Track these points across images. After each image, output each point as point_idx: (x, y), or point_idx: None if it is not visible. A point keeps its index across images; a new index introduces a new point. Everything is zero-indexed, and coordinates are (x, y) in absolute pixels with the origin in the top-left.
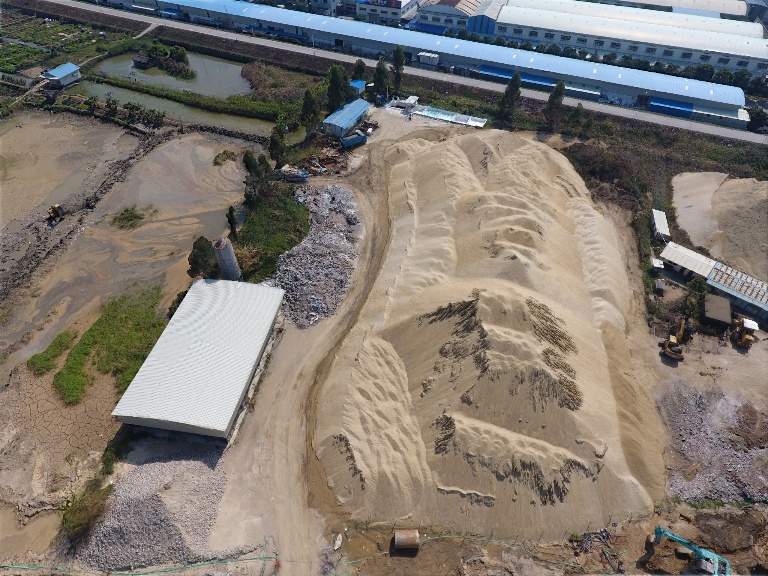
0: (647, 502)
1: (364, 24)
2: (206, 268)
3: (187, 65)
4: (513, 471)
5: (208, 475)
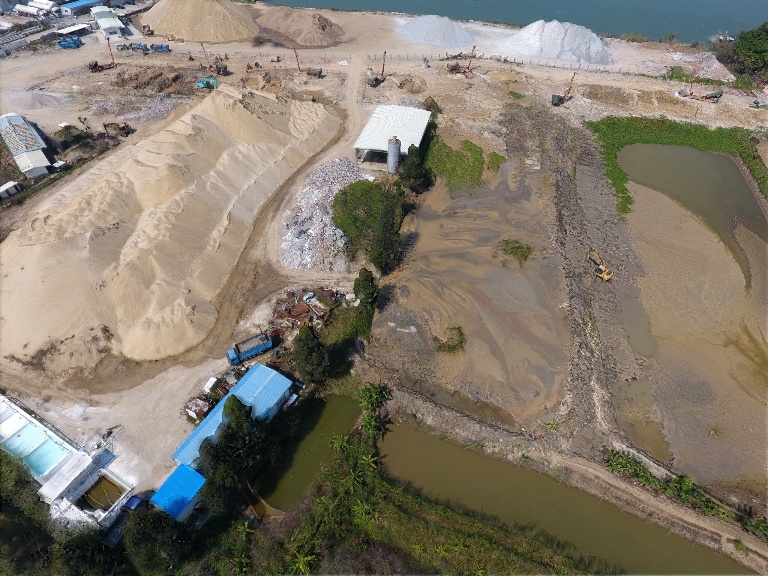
0: None
1: None
2: None
3: None
4: None
5: None
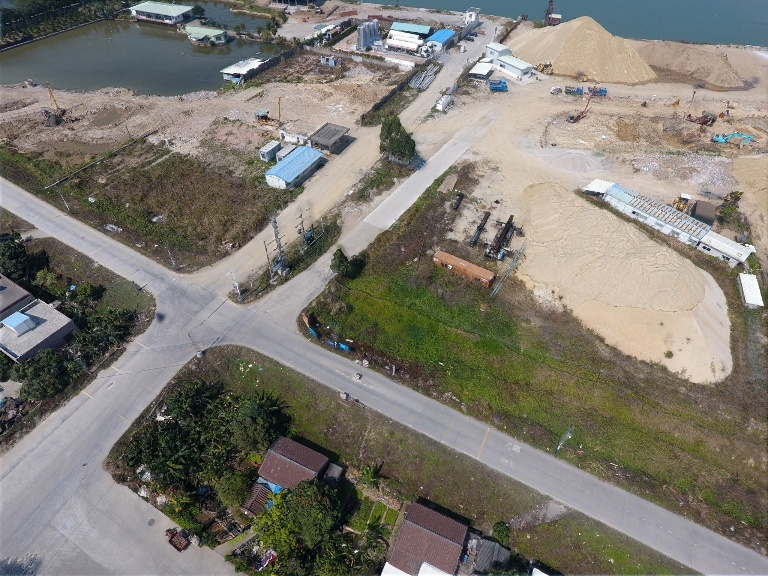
0: None
1: None
2: None
3: None
4: None
5: None
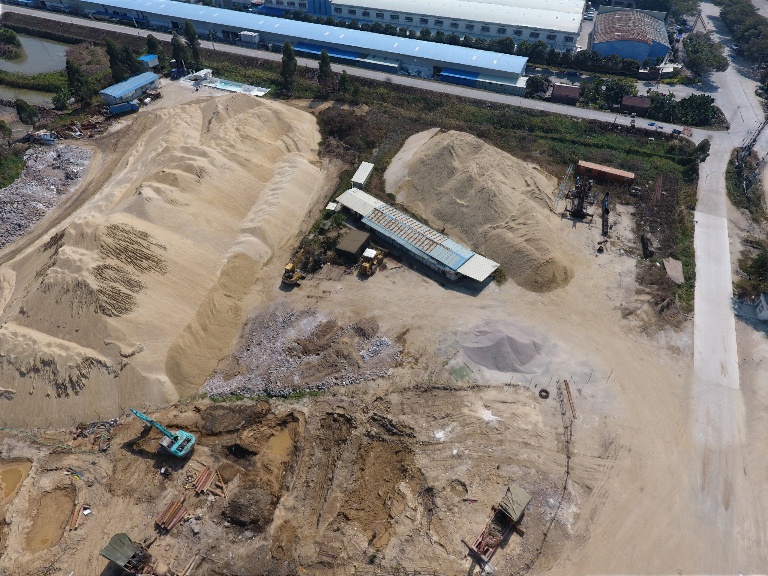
0: (171, 397)
1: (201, 7)
2: None
3: (18, 47)
4: (34, 368)
5: None
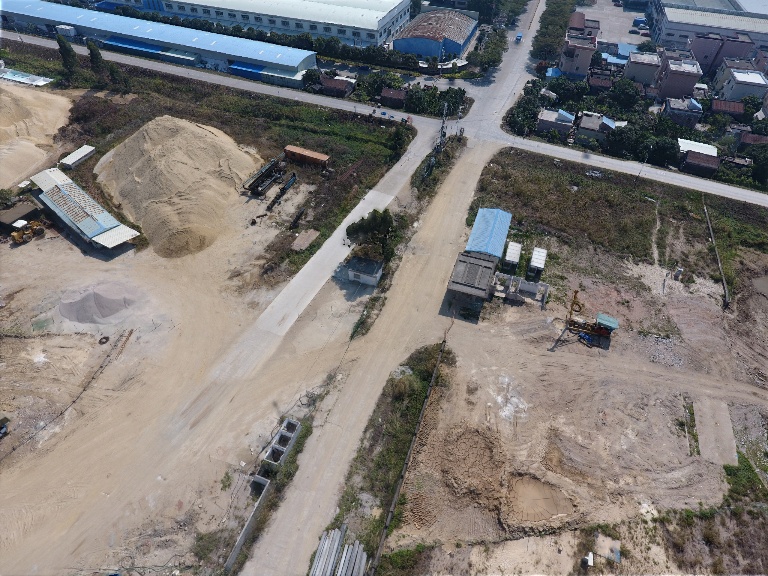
0: None
1: None
2: None
3: None
4: None
5: None
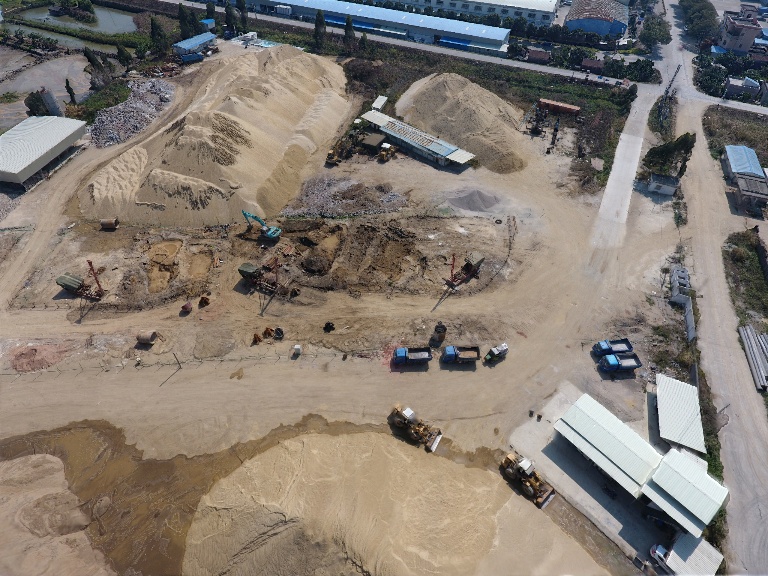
0: (261, 215)
1: None
2: (38, 110)
3: None
4: (177, 192)
5: (7, 200)
